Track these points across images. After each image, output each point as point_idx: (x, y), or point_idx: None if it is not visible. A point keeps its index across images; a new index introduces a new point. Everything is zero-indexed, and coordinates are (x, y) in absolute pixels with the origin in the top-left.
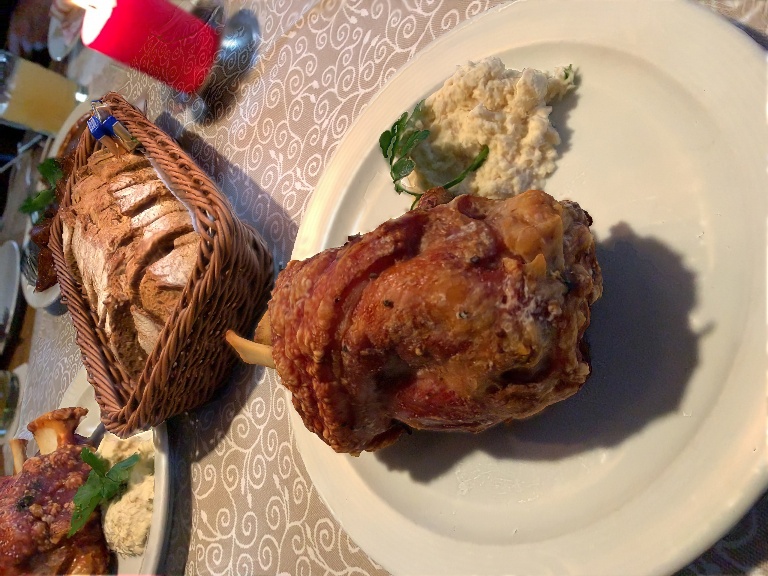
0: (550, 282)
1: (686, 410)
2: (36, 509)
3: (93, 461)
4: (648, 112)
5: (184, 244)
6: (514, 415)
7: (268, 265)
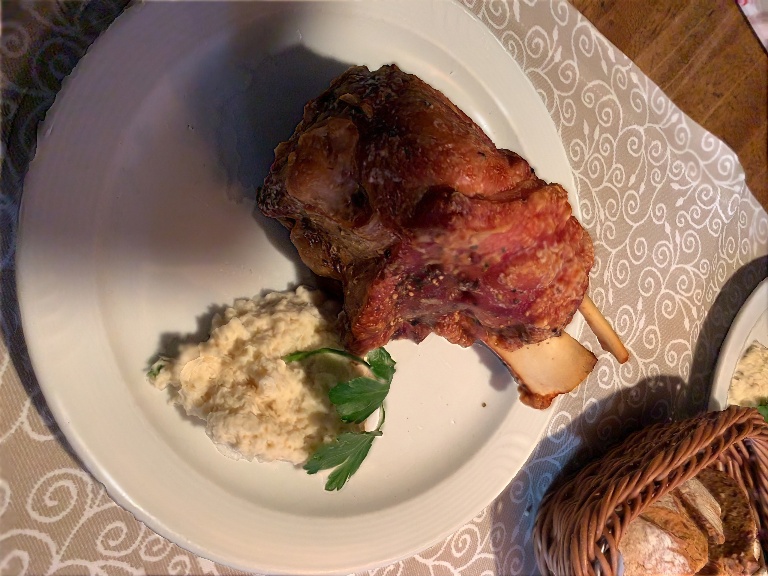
0: None
1: (298, 38)
2: None
3: None
4: (134, 259)
5: None
6: None
7: None
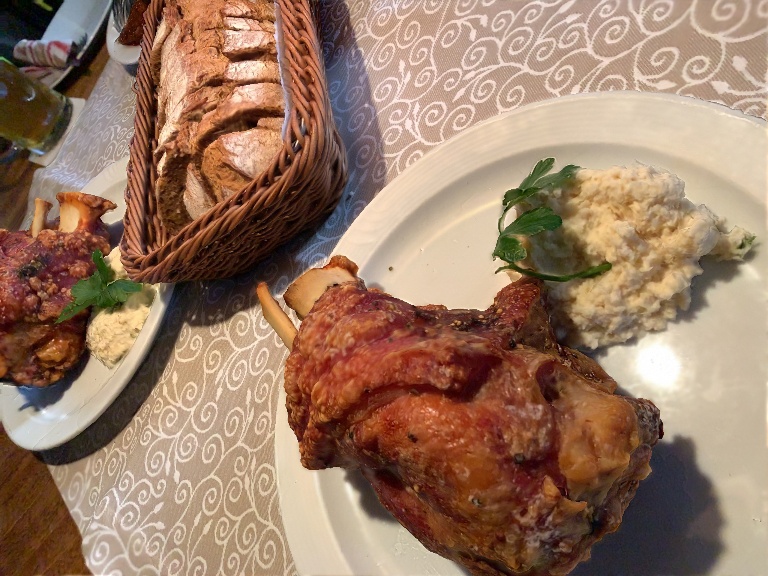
0: (578, 520)
1: None
2: (35, 282)
3: (101, 266)
4: None
5: (267, 128)
6: None
7: (338, 190)
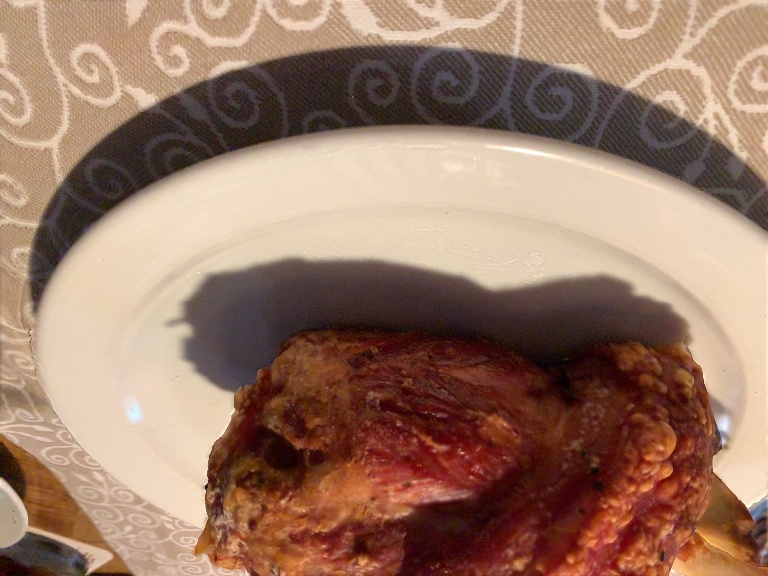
0: None
1: None
2: None
3: None
4: None
5: None
6: (337, 389)
7: (761, 526)
